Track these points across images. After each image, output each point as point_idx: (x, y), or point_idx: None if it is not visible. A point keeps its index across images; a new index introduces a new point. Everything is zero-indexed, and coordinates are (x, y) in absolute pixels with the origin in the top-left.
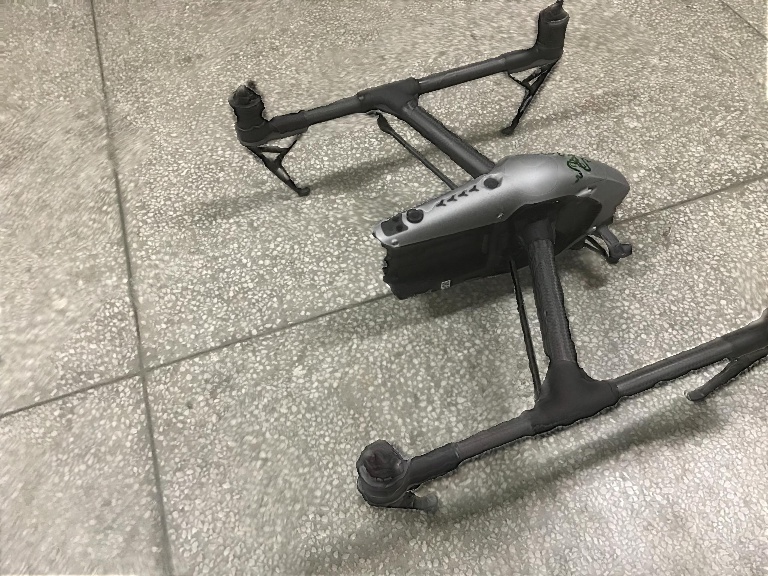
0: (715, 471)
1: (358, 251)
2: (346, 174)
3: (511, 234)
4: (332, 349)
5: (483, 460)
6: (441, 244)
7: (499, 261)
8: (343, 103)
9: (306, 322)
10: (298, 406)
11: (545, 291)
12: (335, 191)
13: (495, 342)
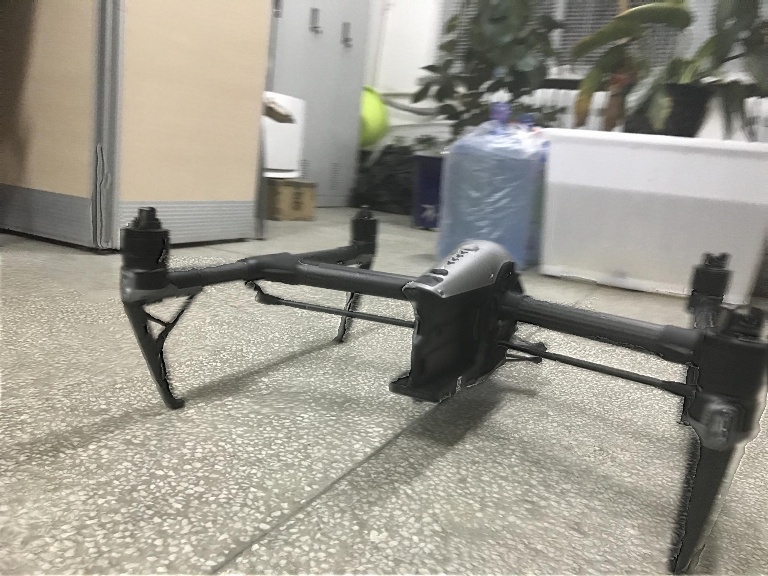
0: (767, 452)
1: (304, 427)
2: (212, 386)
3: (495, 306)
4: (388, 503)
5: (656, 516)
6: (451, 322)
7: (485, 353)
8: (230, 266)
9: (323, 494)
10: (426, 567)
11: (581, 310)
12: (215, 398)
13: (525, 443)
